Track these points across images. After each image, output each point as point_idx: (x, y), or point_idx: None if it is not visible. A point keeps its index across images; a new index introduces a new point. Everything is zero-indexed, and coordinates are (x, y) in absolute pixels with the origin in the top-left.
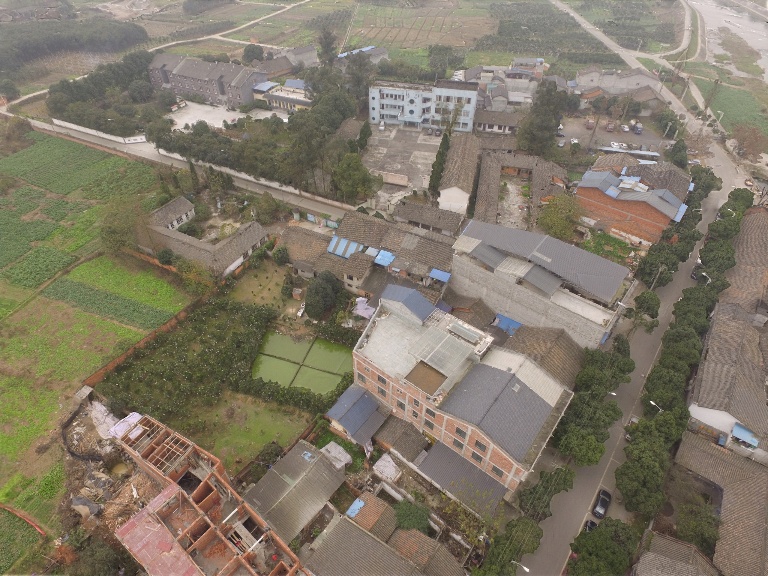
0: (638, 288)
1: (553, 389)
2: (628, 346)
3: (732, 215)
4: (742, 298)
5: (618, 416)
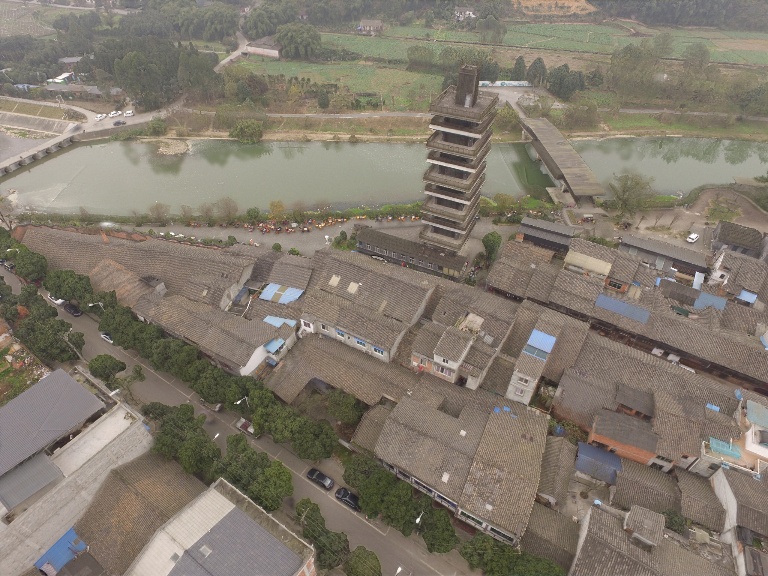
0: (68, 369)
1: (212, 502)
2: (159, 404)
3: (16, 252)
4: (132, 290)
5: (244, 439)
